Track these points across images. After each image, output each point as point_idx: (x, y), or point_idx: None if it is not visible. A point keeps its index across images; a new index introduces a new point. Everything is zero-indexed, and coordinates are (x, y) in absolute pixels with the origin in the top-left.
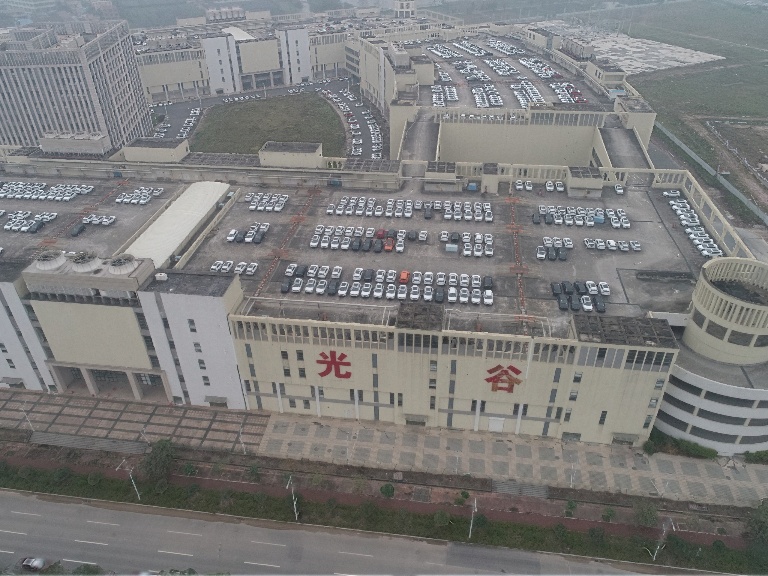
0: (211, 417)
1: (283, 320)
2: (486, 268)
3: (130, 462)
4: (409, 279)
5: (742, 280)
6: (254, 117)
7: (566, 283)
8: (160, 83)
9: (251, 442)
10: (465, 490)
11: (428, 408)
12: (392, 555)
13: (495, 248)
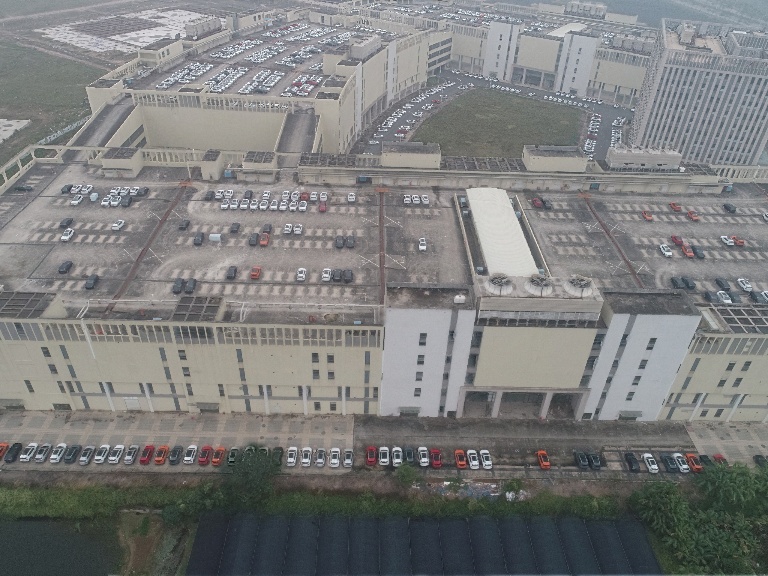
0: None
1: None
2: None
3: None
4: None
5: None
6: None
7: (435, 7)
8: None
9: None
10: None
11: None
12: None
13: None
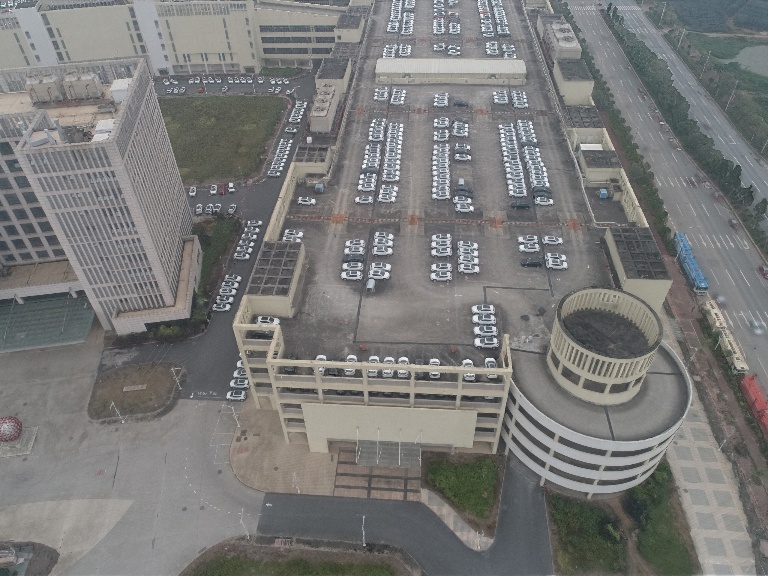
0: None
1: None
2: (467, 1)
3: None
4: None
5: None
6: None
7: None
8: None
9: None
10: None
11: None
12: None
13: None
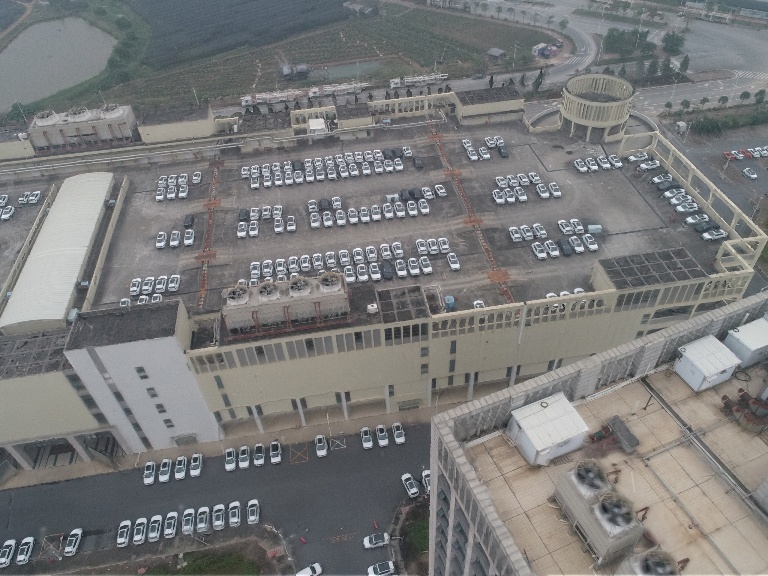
0: None
1: None
2: None
3: None
4: None
5: None
6: None
7: None
8: None
9: None
10: None
11: None
12: None
13: None
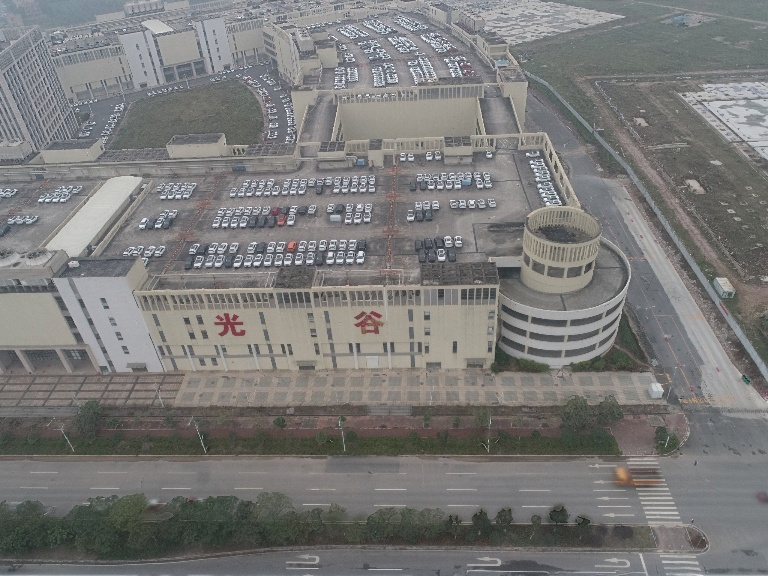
0: (134, 380)
1: (180, 291)
2: (363, 233)
3: (65, 423)
4: (296, 248)
5: (564, 224)
6: (177, 109)
7: (426, 240)
8: (83, 82)
9: (168, 397)
10: (345, 416)
11: (314, 354)
12: (282, 470)
13: (373, 215)
